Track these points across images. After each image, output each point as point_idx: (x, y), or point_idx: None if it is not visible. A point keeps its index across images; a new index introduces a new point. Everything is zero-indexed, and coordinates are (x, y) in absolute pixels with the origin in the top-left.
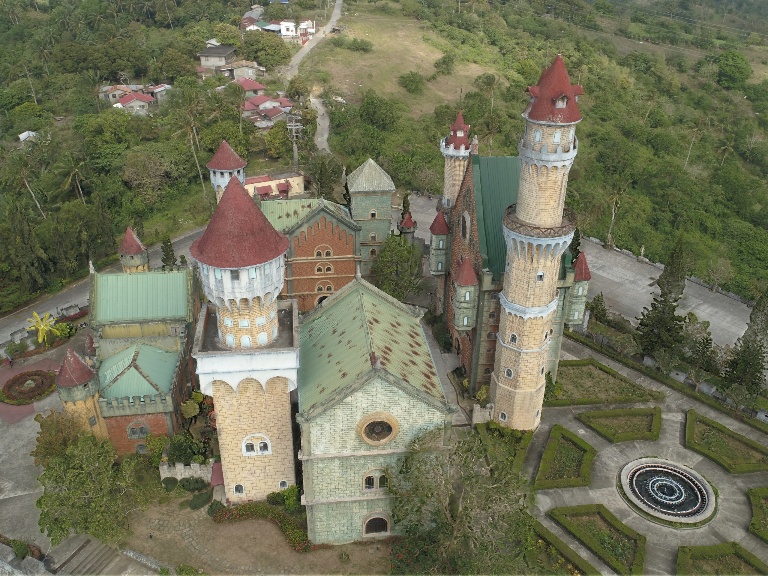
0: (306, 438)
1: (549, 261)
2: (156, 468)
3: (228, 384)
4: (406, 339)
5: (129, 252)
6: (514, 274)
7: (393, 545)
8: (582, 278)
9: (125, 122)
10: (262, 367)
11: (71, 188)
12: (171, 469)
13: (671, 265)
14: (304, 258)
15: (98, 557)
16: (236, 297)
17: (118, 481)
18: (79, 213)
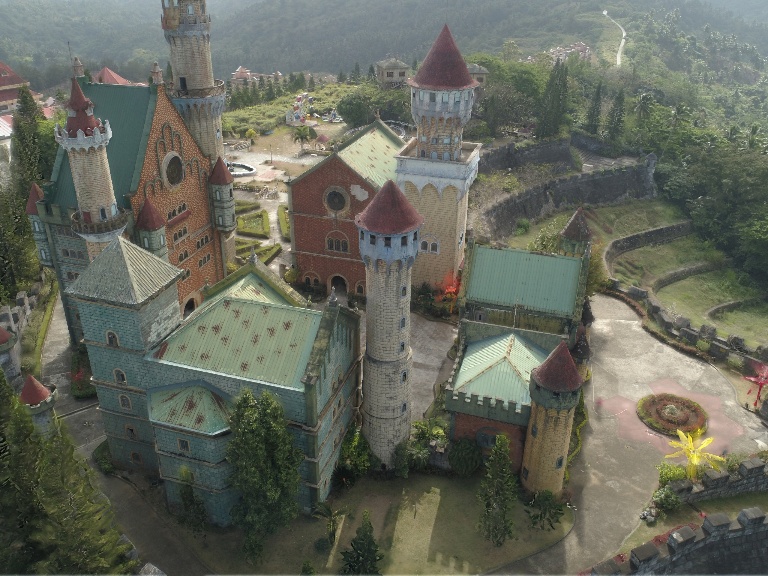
0: None
1: None
2: None
3: None
4: None
5: None
6: None
7: None
8: None
9: None
10: None
11: None
12: None
13: None
14: None
15: None
16: None
17: None
18: None
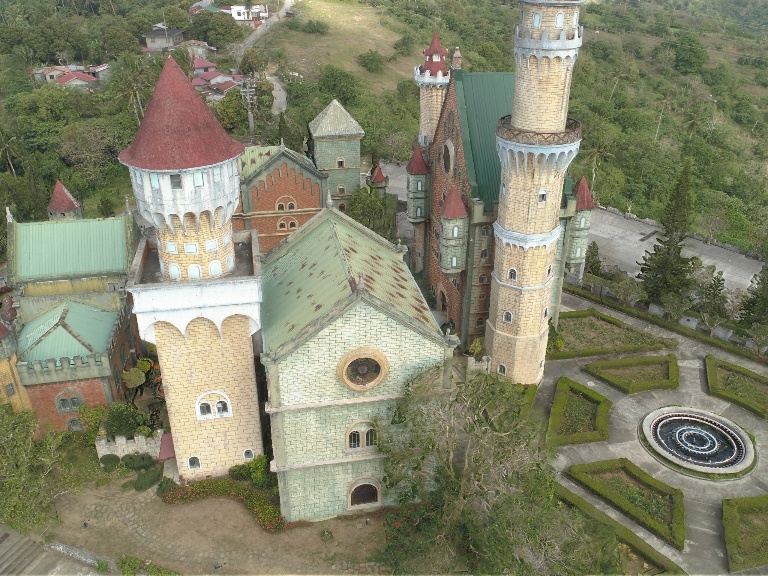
0: (274, 384)
1: (552, 177)
2: (93, 446)
3: (174, 327)
4: (389, 272)
5: (59, 209)
6: (511, 195)
7: (387, 514)
8: (584, 207)
9: (62, 97)
10: (216, 302)
11: (2, 167)
12: (110, 444)
13: (676, 198)
14: (264, 212)
15: (18, 554)
16: (179, 211)
17: (40, 457)
18: (7, 183)
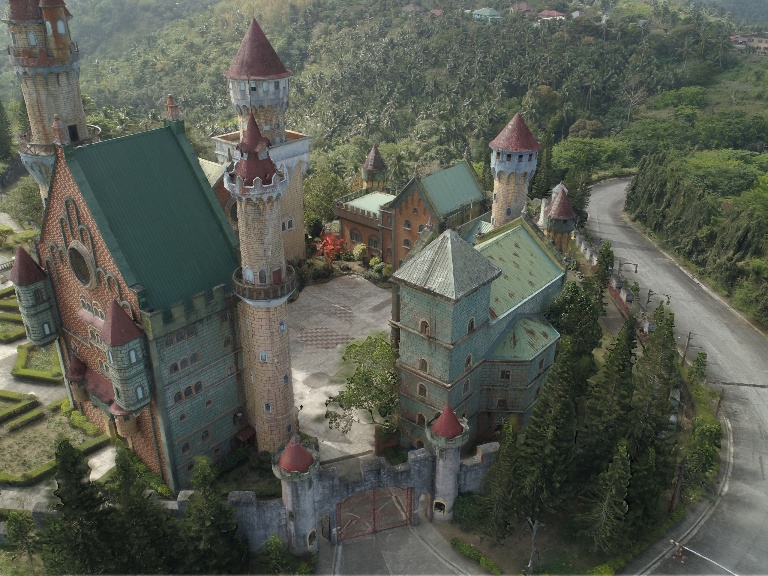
0: None
1: None
2: None
3: None
4: None
5: None
6: None
7: None
8: None
9: None
10: None
11: None
12: None
13: None
14: None
15: None
16: None
17: None
18: None
